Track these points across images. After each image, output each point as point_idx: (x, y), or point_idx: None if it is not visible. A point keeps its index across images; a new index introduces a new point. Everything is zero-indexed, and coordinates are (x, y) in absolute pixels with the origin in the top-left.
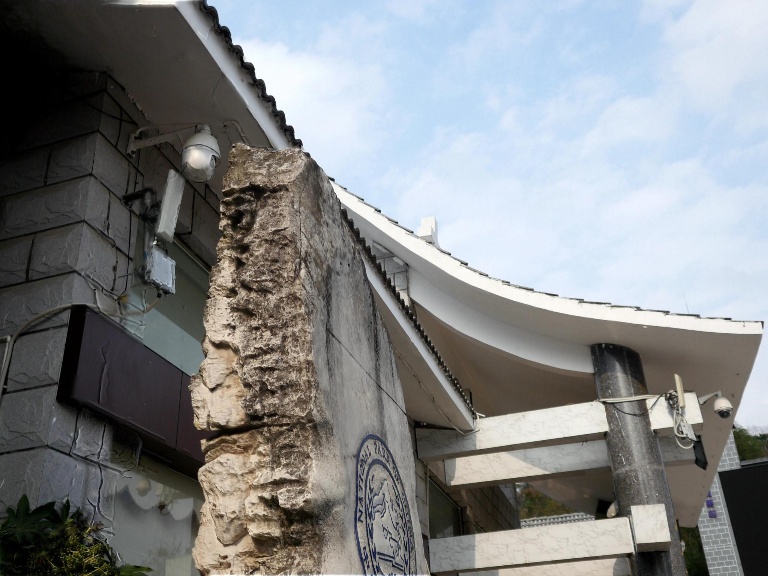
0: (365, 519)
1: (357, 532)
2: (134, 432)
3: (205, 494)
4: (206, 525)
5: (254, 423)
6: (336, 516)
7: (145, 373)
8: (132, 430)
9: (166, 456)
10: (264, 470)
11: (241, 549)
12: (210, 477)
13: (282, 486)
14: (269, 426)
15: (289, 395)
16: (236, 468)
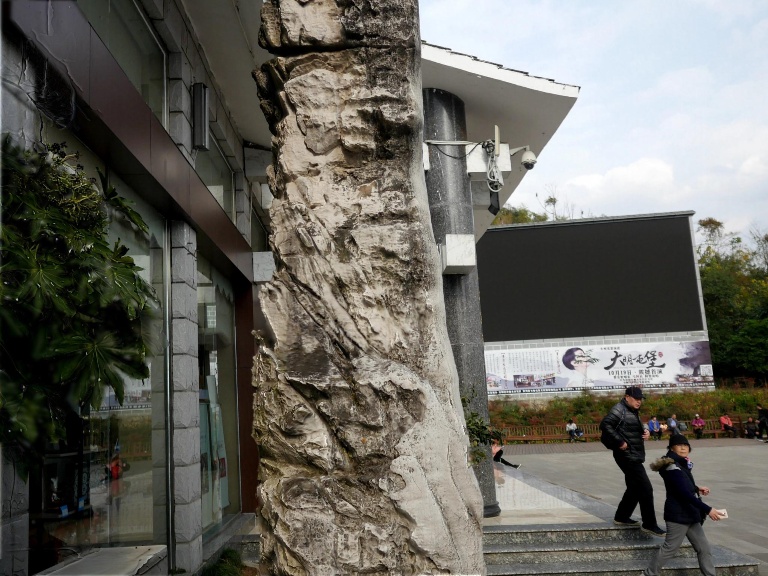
0: None
1: None
2: (68, 78)
3: (288, 108)
4: (292, 136)
5: (352, 42)
6: (419, 138)
7: (66, 17)
8: (67, 75)
9: (86, 113)
10: (359, 88)
11: (331, 159)
12: (301, 90)
13: (381, 103)
14: (367, 46)
15: (390, 18)
16: (332, 83)
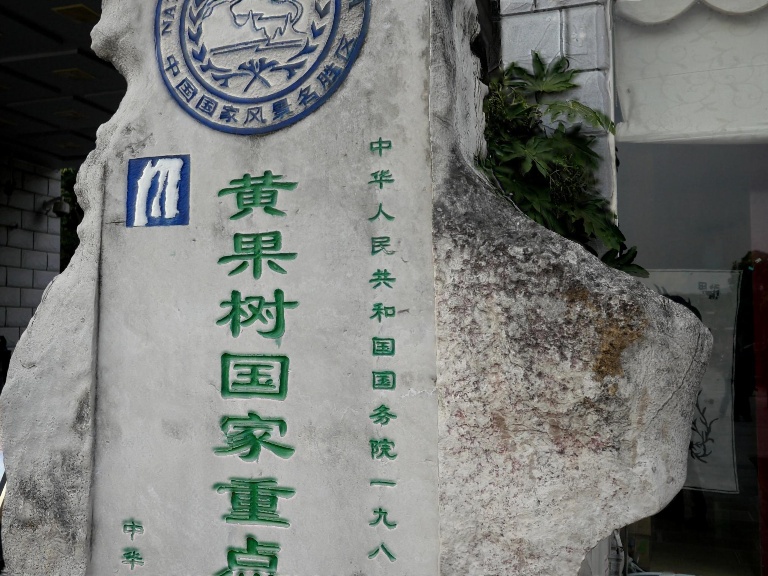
0: (179, 26)
1: (160, 46)
2: None
3: None
4: None
5: None
6: (124, 45)
7: None
8: None
9: None
10: None
11: None
12: None
13: None
14: None
15: None
16: None
